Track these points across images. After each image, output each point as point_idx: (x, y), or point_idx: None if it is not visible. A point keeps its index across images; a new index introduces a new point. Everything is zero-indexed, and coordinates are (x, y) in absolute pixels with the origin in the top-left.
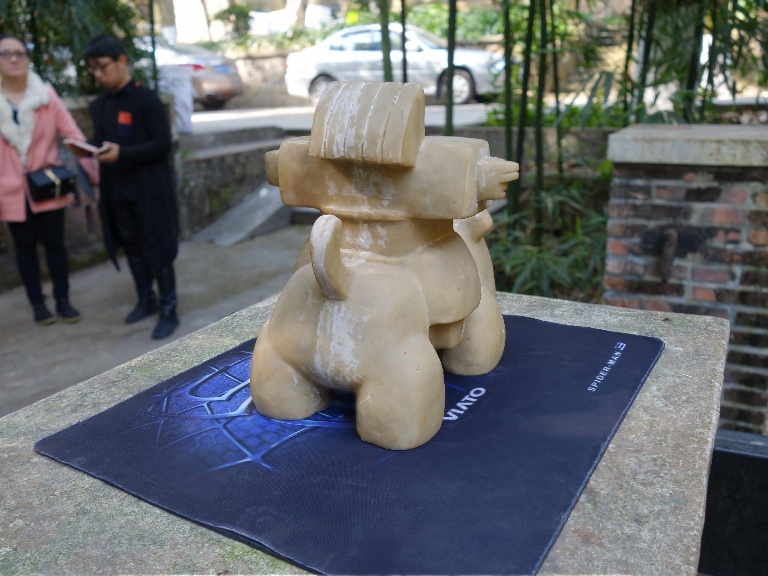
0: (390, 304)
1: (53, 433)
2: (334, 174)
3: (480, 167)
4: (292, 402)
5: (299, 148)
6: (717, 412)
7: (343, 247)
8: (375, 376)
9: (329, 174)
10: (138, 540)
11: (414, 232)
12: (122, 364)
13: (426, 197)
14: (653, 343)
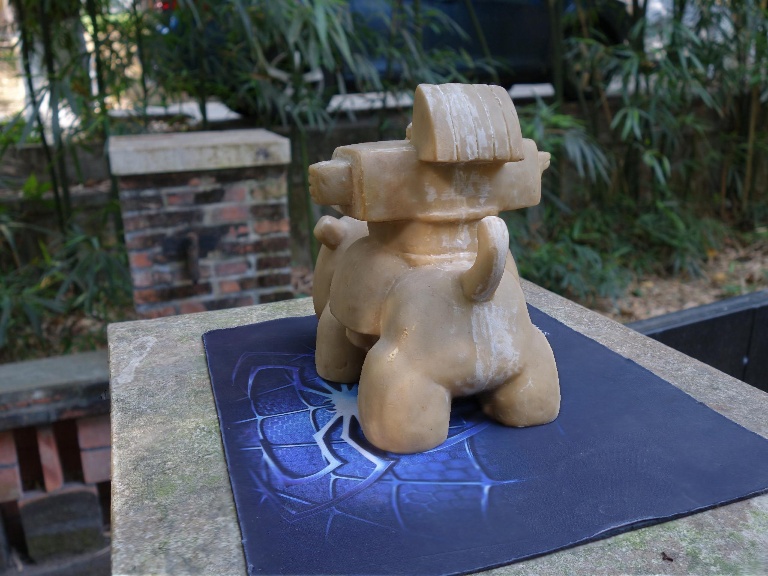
0: (521, 292)
1: None
2: (434, 179)
3: None
4: (445, 424)
5: (391, 156)
6: None
7: (437, 253)
8: (532, 361)
9: (429, 180)
10: None
11: None
12: (115, 502)
13: (514, 190)
14: None
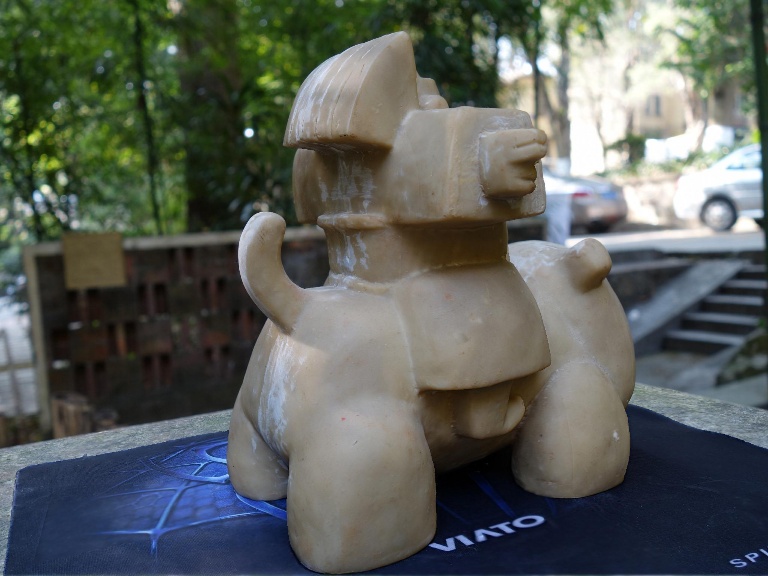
0: (335, 343)
1: None
2: (325, 173)
3: (483, 141)
4: (250, 473)
5: None
6: None
7: (337, 272)
8: (299, 447)
9: (321, 174)
10: None
11: (403, 247)
12: (203, 414)
13: (404, 190)
14: None
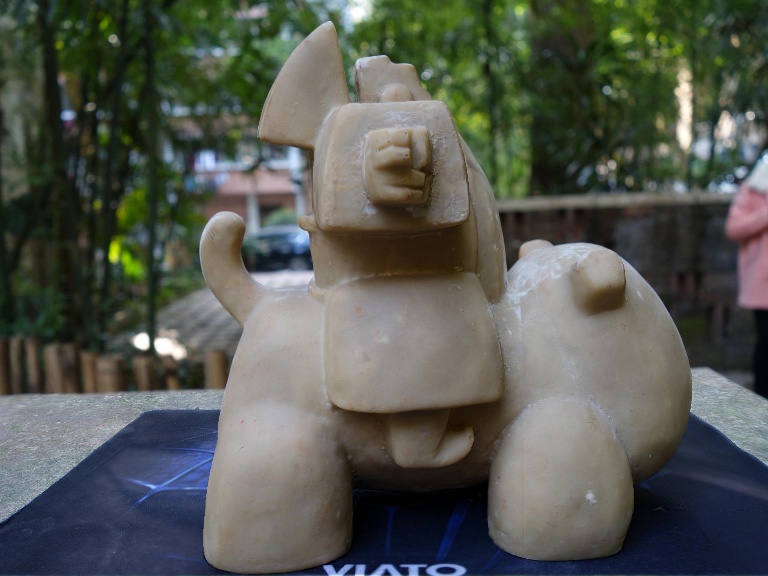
0: (253, 346)
1: None
2: None
3: (365, 142)
4: None
5: None
6: None
7: None
8: None
9: None
10: (5, 495)
11: (332, 252)
12: None
13: None
14: None
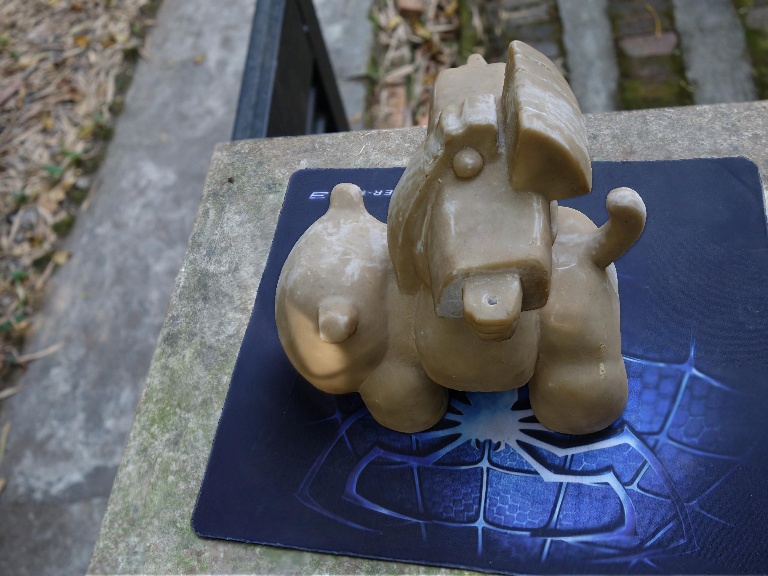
0: None
1: None
2: None
3: None
4: None
5: (546, 228)
6: (424, 126)
7: None
8: None
9: None
10: None
11: None
12: None
13: None
14: (303, 176)
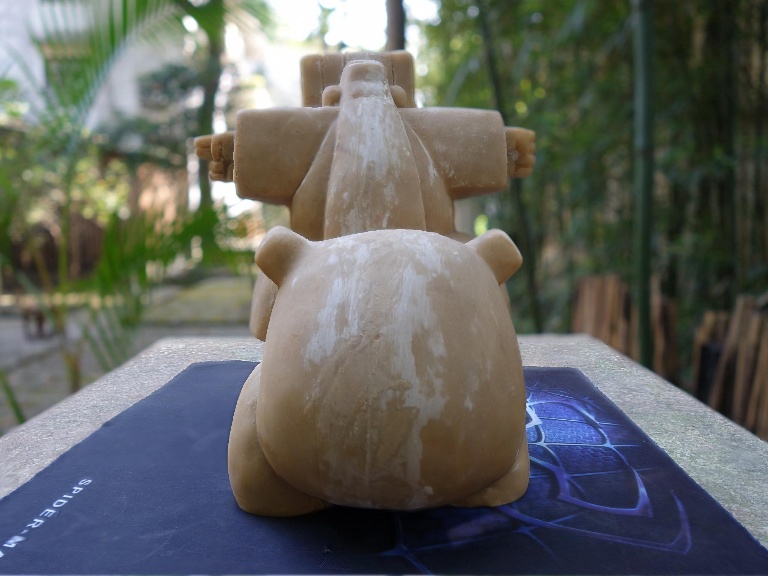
0: None
1: (594, 379)
2: None
3: None
4: None
5: None
6: None
7: None
8: None
9: None
10: None
11: None
12: None
13: None
14: None
